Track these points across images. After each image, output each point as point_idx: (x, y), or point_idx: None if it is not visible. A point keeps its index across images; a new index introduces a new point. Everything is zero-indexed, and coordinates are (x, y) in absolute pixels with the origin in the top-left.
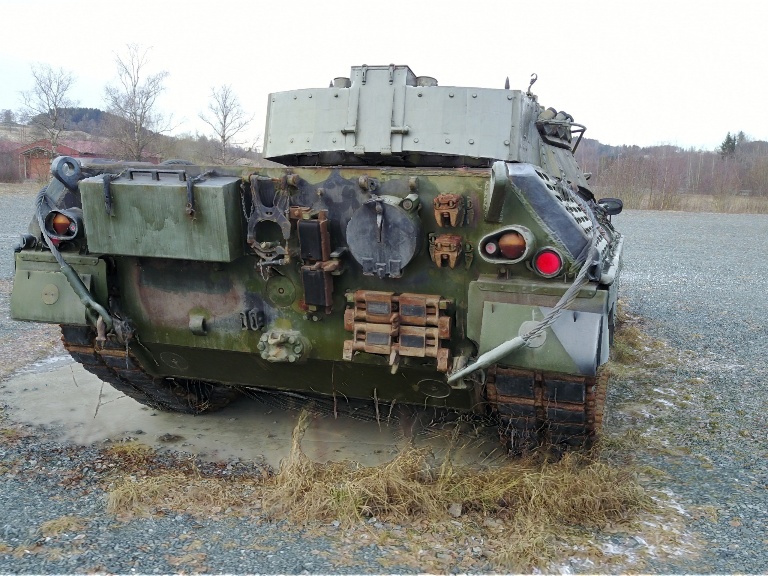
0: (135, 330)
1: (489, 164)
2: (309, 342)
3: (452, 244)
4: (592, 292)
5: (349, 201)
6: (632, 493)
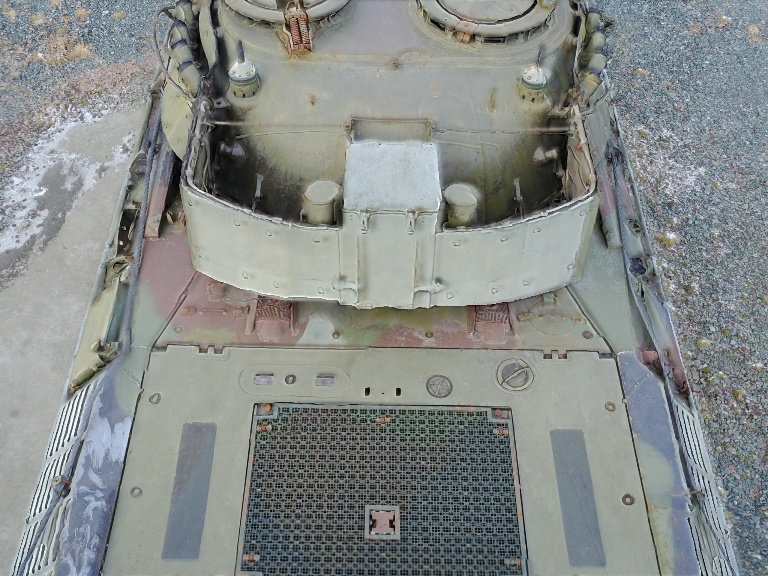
0: None
1: (517, 212)
2: None
3: None
4: None
5: None
6: None
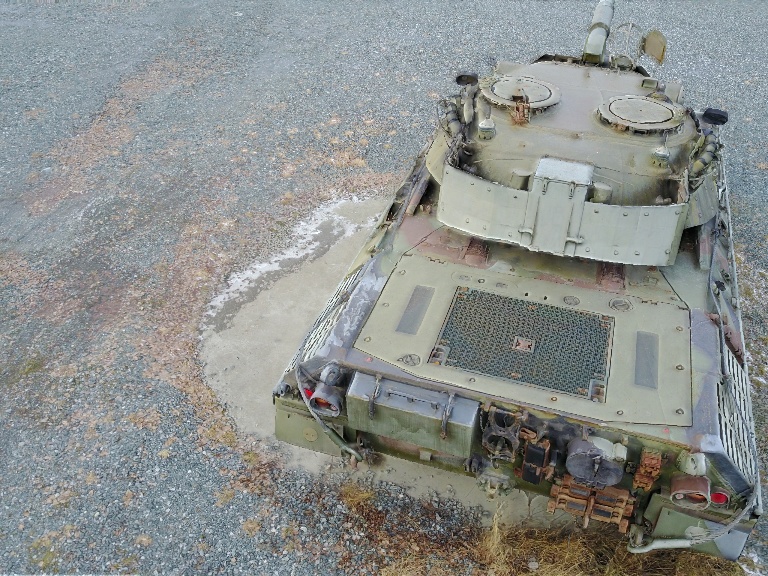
0: (372, 447)
1: None
2: (515, 482)
3: (649, 483)
4: (746, 521)
5: (568, 432)
6: None
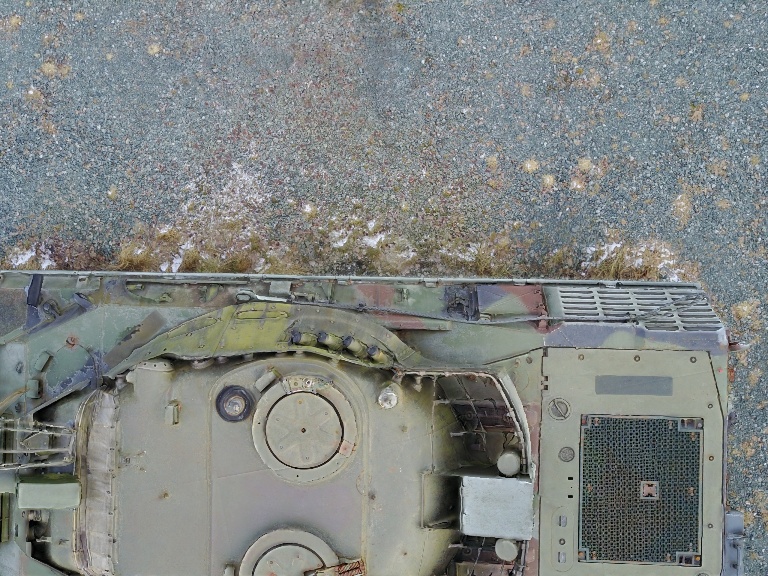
0: None
1: None
2: None
3: None
4: None
5: None
6: (627, 269)
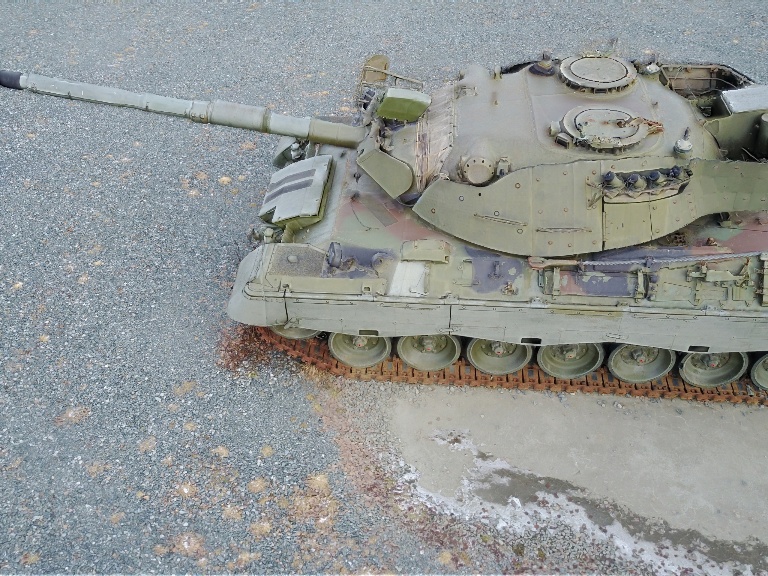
0: None
1: None
2: None
3: None
4: None
5: None
6: None
